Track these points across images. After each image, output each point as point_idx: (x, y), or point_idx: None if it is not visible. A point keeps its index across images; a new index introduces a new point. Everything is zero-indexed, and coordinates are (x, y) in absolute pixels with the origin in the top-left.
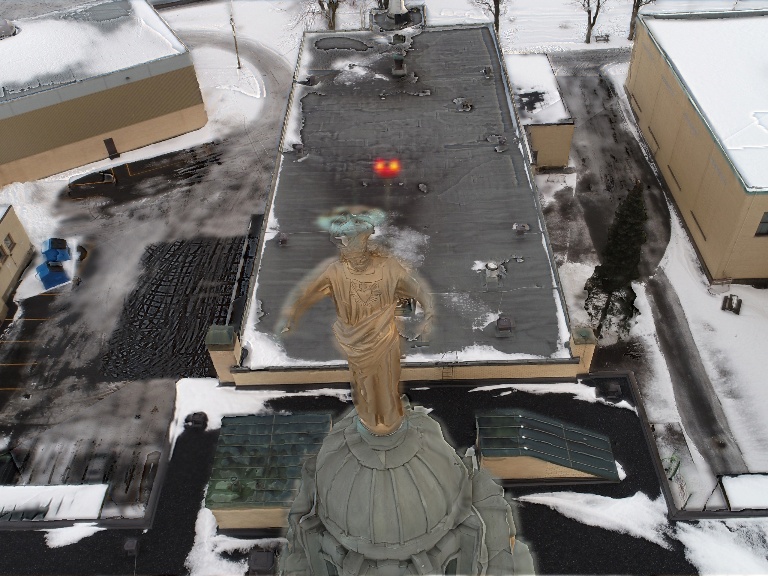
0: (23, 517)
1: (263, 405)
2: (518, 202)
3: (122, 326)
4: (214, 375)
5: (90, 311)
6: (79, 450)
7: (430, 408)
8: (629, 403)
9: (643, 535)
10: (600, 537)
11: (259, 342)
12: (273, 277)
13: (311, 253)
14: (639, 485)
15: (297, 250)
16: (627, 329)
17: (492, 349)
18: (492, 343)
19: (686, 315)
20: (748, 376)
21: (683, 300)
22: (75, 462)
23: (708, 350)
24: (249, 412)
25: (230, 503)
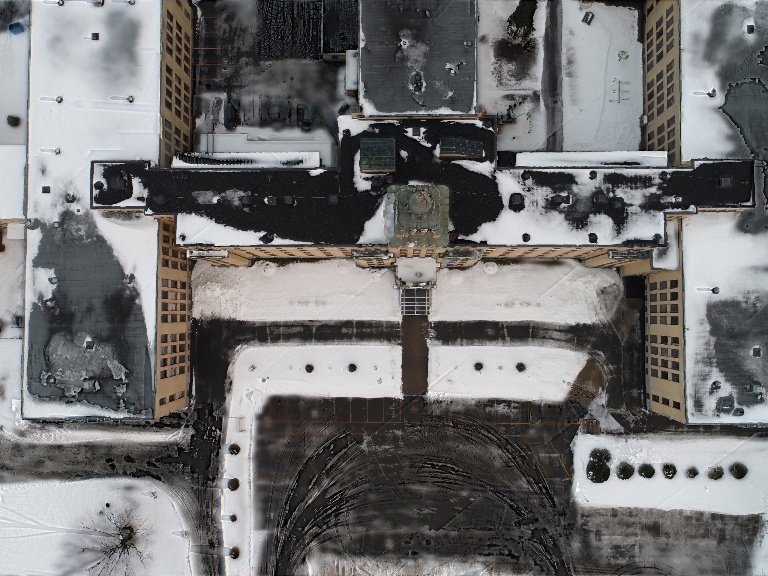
0: (296, 164)
1: (369, 126)
2: (469, 27)
3: (261, 24)
4: (318, 58)
5: (240, 12)
6: (262, 100)
7: (426, 129)
8: (493, 128)
9: (486, 174)
10: (473, 174)
11: (366, 104)
12: (367, 70)
13: (381, 56)
14: (489, 158)
15: (375, 54)
16: (527, 39)
17: (449, 109)
18: (449, 106)
19: (563, 24)
20: (581, 64)
21: (564, 13)
22: (263, 107)
23: (567, 48)
24: (364, 129)
25: (367, 168)
